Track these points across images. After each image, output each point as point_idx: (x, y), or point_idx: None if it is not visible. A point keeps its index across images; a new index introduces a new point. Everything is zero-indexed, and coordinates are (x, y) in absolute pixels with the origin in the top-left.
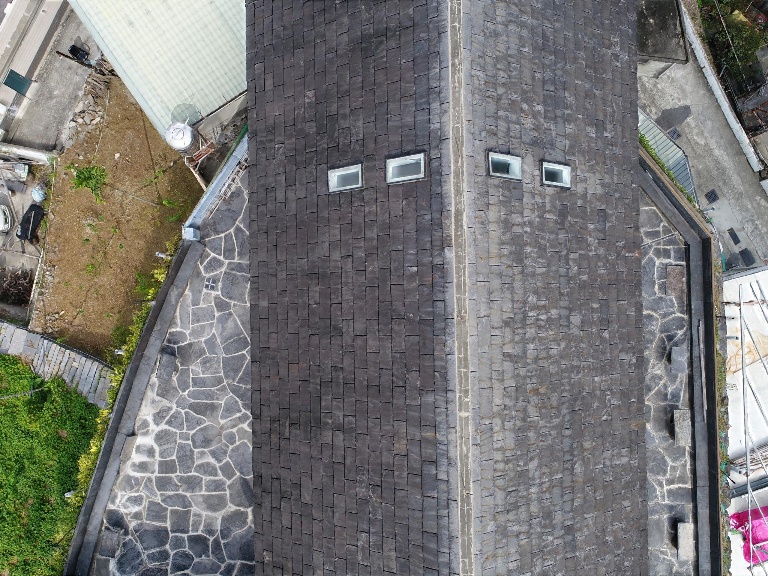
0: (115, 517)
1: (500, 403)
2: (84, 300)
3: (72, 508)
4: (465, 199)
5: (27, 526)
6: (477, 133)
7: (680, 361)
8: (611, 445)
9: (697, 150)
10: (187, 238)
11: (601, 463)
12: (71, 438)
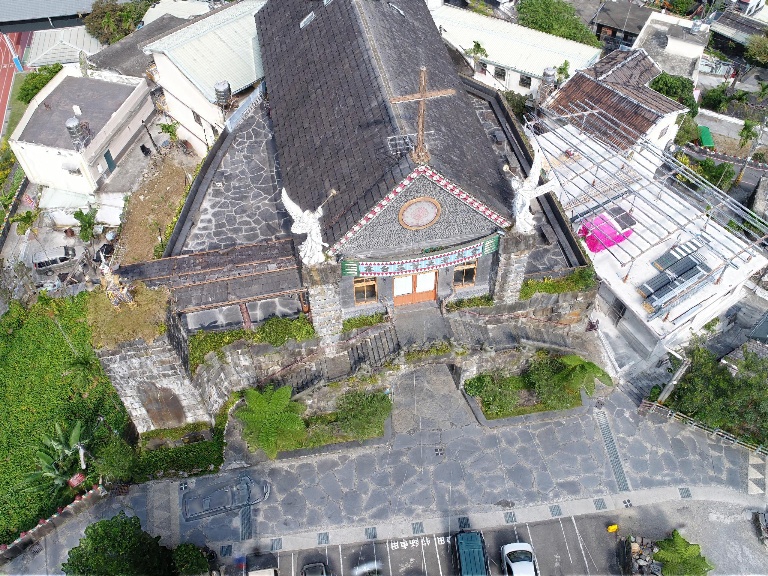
0: None
1: (387, 43)
2: None
3: None
4: None
5: None
6: None
7: (501, 136)
8: None
9: None
10: (227, 125)
11: None
12: None
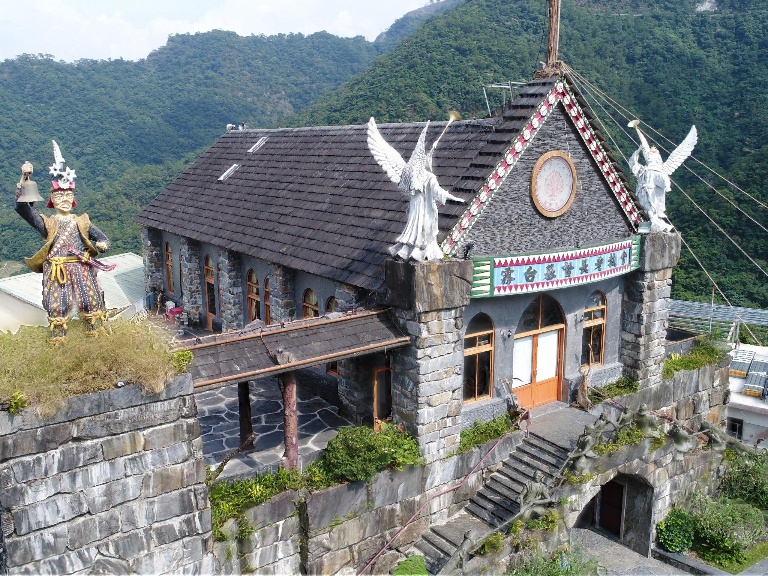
0: None
1: None
2: None
3: None
4: None
5: None
6: None
7: None
8: None
9: None
10: None
11: None
12: None
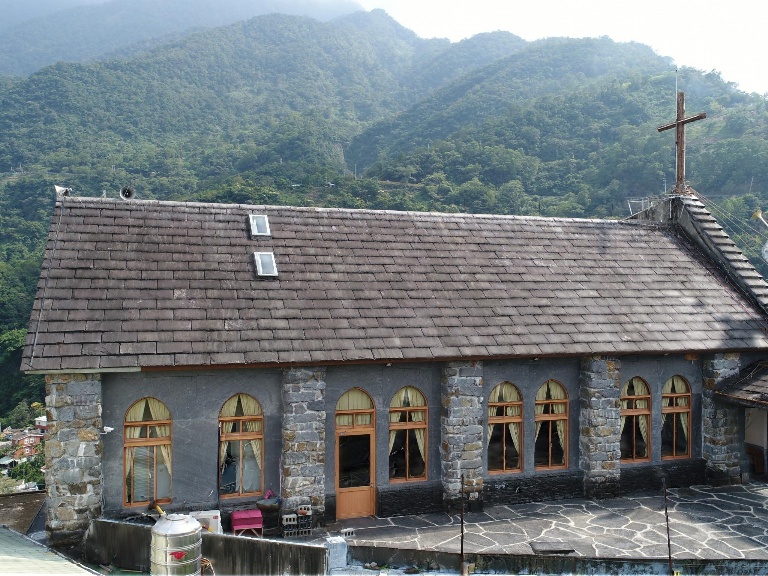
0: None
1: None
2: None
3: None
4: None
5: None
6: None
7: None
8: None
9: None
10: None
11: None
12: None
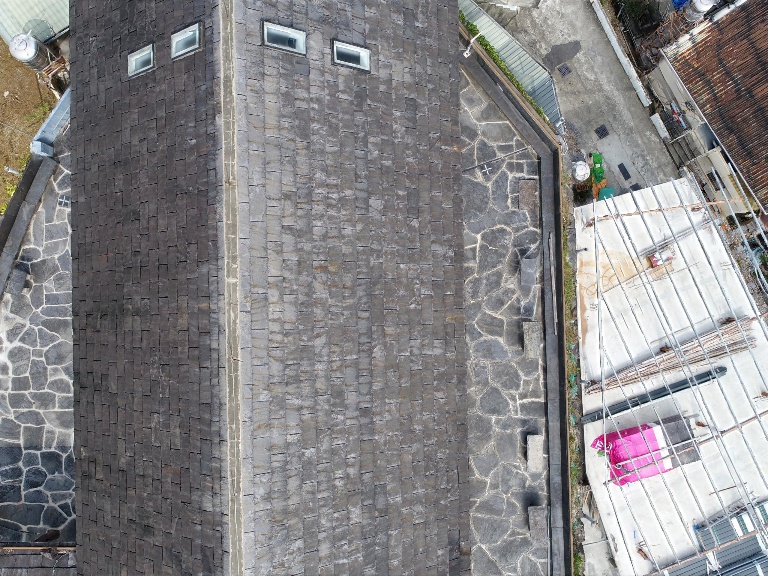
0: None
1: (278, 274)
2: None
3: None
4: (234, 65)
5: None
6: (250, 2)
7: (529, 273)
8: (420, 334)
9: (587, 85)
10: (35, 152)
11: (407, 351)
12: None
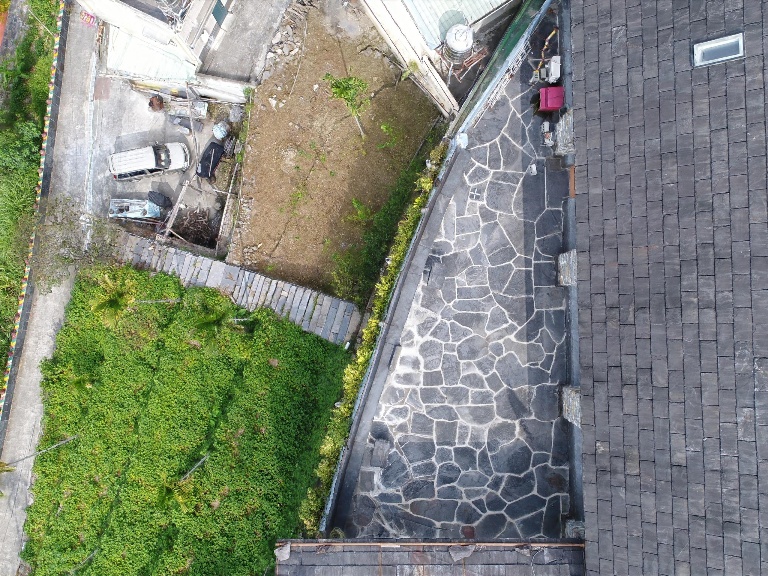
0: (380, 429)
1: None
2: (283, 232)
3: (339, 419)
4: None
5: (238, 456)
6: None
7: None
8: None
9: None
10: (461, 144)
11: None
12: (284, 367)
